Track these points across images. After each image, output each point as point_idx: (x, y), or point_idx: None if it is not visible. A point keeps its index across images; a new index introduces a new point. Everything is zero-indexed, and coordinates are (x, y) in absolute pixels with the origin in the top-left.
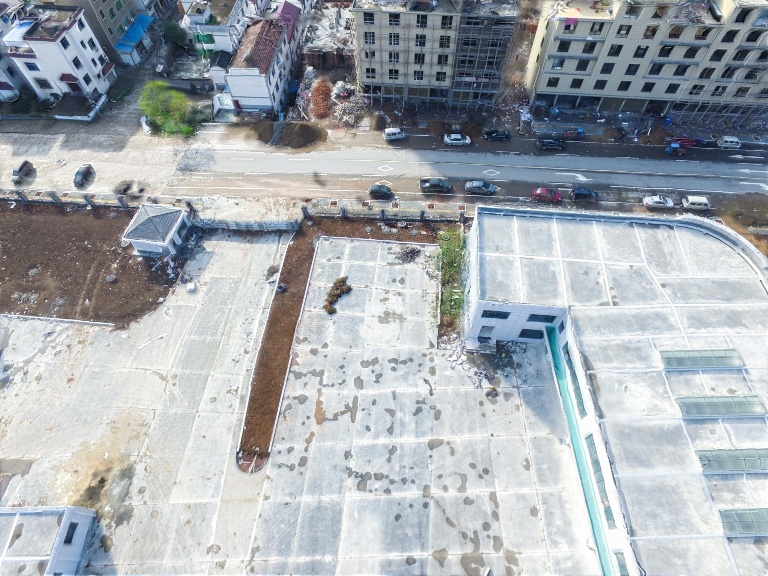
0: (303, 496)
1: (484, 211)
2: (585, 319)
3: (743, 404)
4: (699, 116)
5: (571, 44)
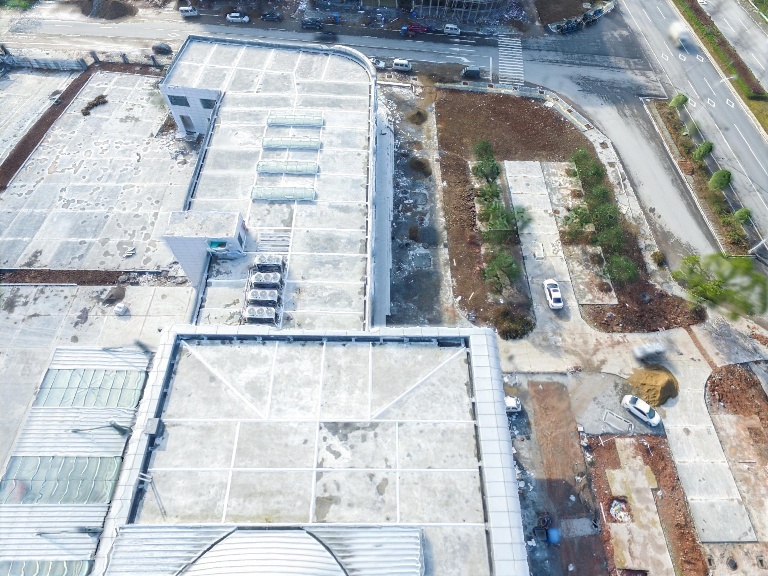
0: (22, 209)
1: (196, 40)
2: (231, 99)
3: (305, 141)
4: (435, 10)
5: None
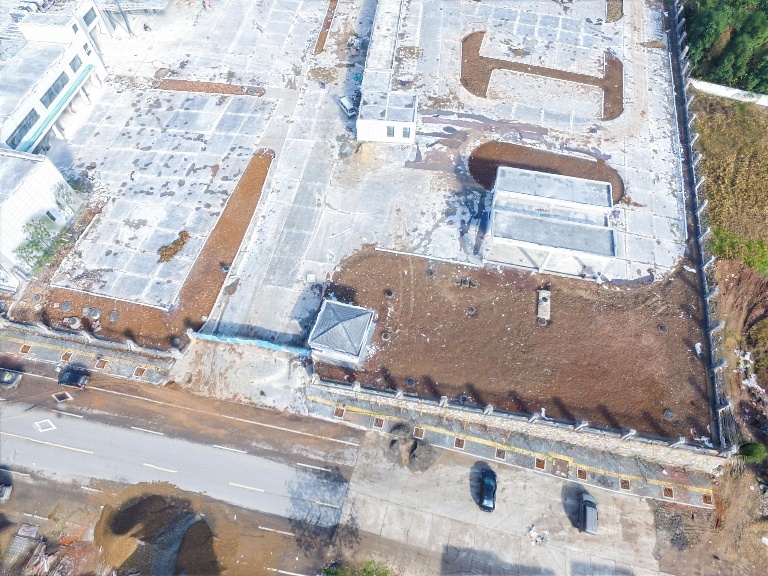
0: (237, 135)
1: None
2: None
3: None
4: None
5: None
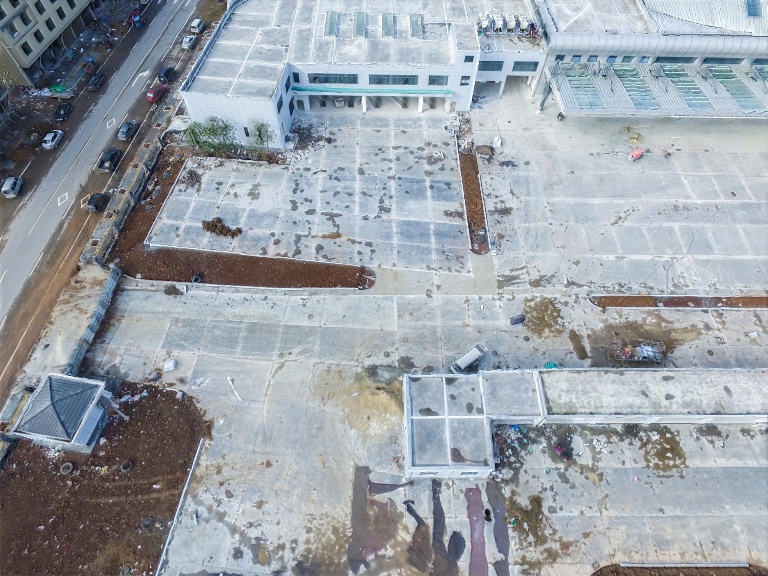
0: (393, 243)
1: None
2: (296, 59)
3: (359, 17)
4: (111, 1)
5: (1, 7)
